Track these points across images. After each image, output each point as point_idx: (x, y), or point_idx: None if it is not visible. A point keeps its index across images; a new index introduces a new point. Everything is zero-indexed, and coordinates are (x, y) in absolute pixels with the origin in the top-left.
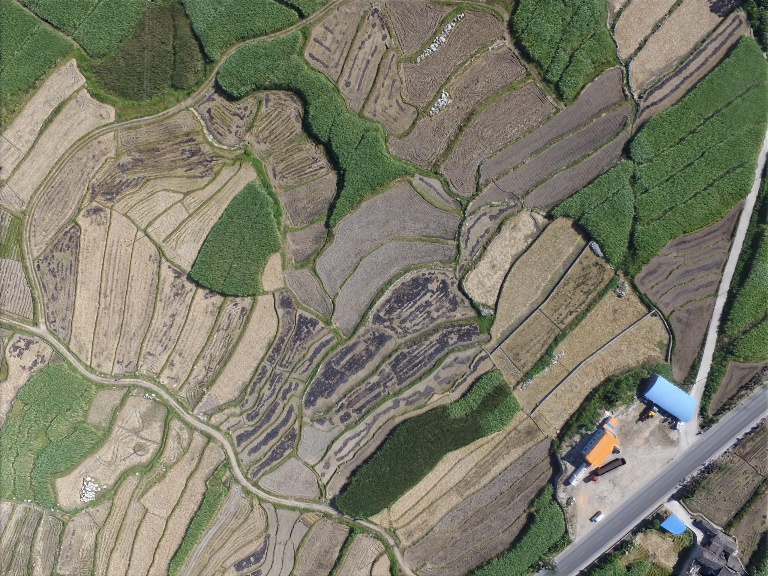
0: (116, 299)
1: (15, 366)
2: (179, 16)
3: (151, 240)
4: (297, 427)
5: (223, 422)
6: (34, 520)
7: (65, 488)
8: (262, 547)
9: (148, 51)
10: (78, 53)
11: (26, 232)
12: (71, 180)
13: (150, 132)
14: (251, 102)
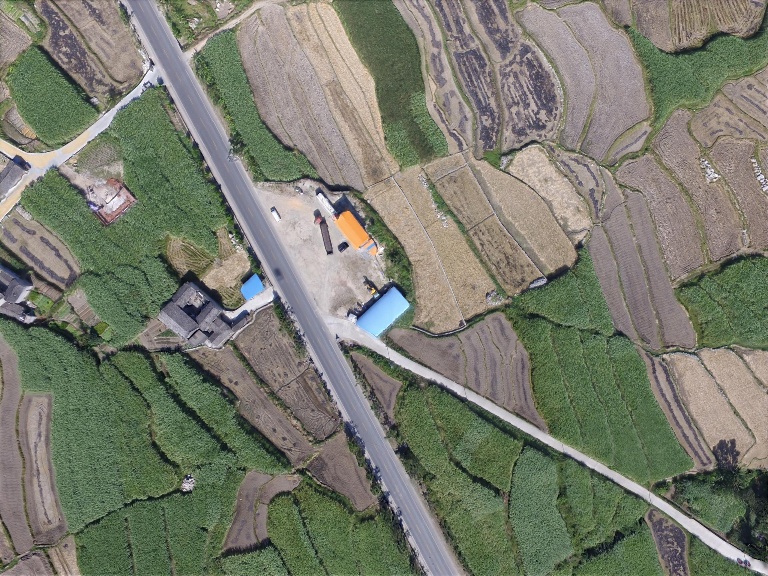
0: None
1: None
2: None
3: None
4: None
5: None
6: None
7: None
8: None
9: None
10: None
11: None
12: None
13: None
14: None
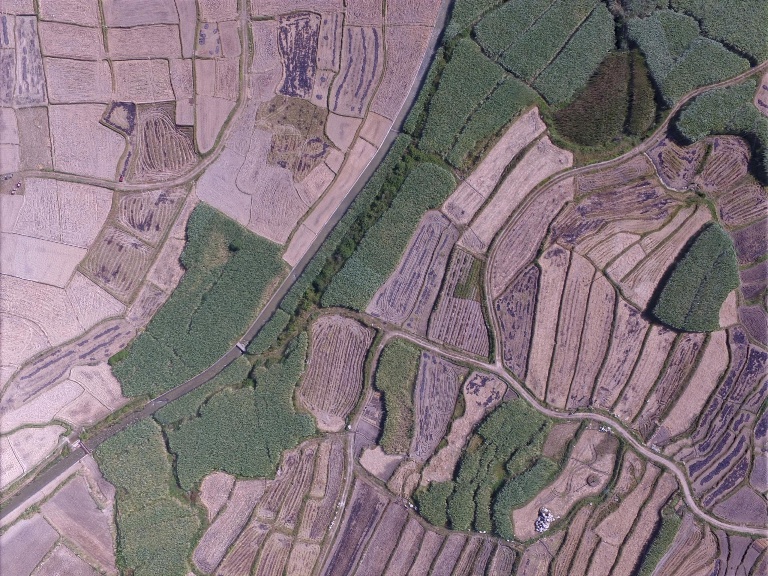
0: (572, 337)
1: (472, 402)
2: (639, 66)
3: (608, 280)
4: (749, 457)
5: (676, 453)
6: (487, 550)
7: (521, 519)
8: (713, 572)
9: (605, 99)
10: (541, 101)
11: (488, 274)
12: (531, 223)
13: (606, 176)
14: (699, 146)
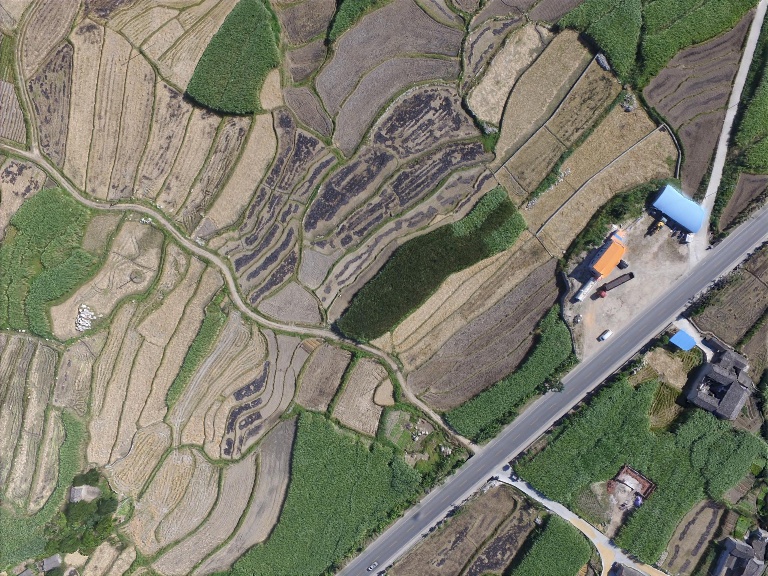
0: (111, 121)
1: (8, 192)
2: None
3: (146, 58)
4: (297, 250)
5: (221, 246)
6: (29, 351)
7: (60, 317)
8: (262, 375)
9: None
10: None
11: (18, 51)
12: None
13: None
14: None
